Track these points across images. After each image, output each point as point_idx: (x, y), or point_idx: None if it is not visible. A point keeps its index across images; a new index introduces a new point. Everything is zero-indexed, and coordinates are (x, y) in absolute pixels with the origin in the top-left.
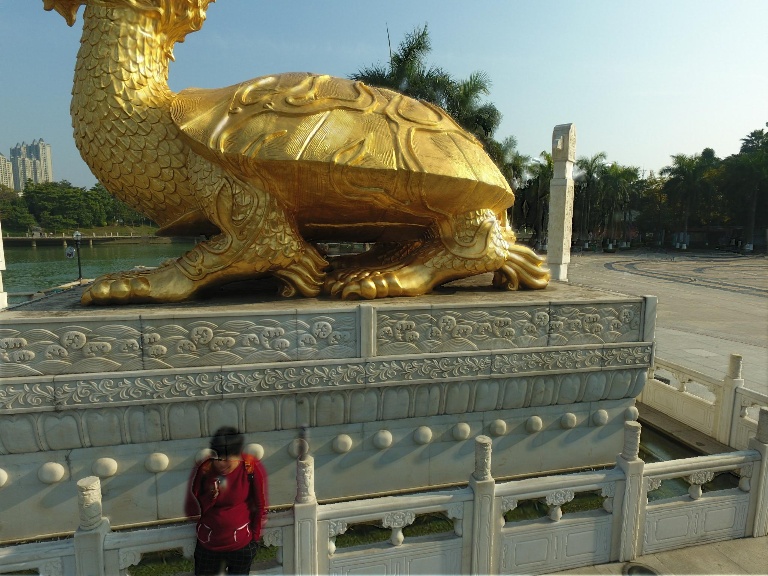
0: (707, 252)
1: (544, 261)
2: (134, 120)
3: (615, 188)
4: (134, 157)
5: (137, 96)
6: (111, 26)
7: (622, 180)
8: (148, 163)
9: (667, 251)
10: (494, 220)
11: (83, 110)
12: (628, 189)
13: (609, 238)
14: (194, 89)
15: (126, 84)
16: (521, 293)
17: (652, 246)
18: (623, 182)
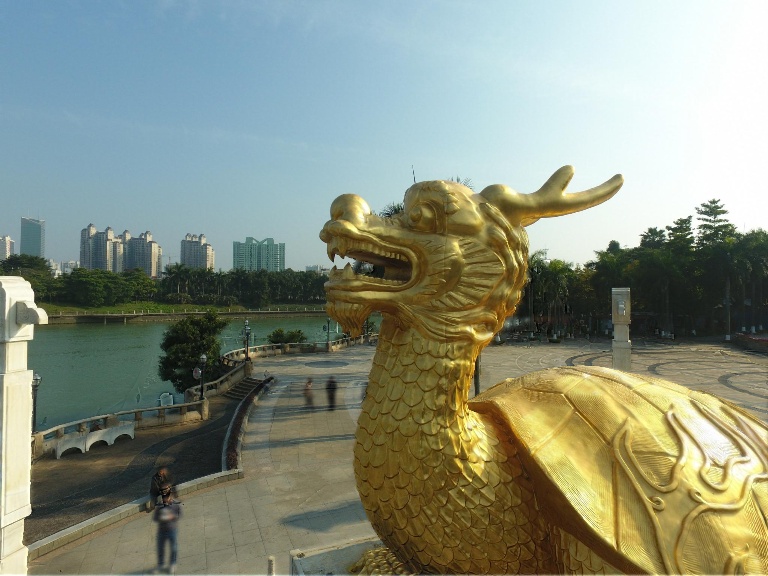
0: (641, 343)
1: (508, 359)
2: (475, 486)
3: (555, 283)
4: (477, 538)
5: (471, 448)
6: (452, 367)
7: (560, 275)
8: (492, 543)
9: (602, 339)
10: None
11: (408, 476)
12: (567, 284)
13: (553, 329)
14: (517, 420)
15: (461, 436)
16: None
17: (589, 335)
18: (561, 277)
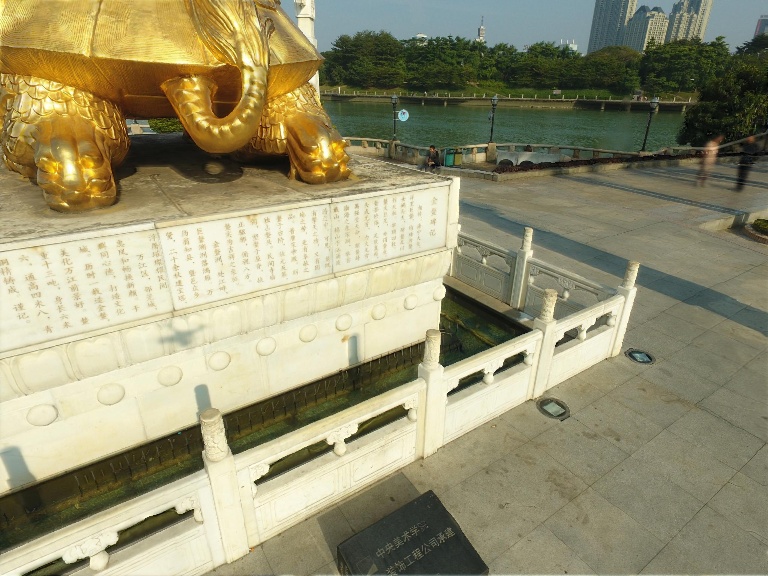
0: None
1: None
2: None
3: None
4: None
5: None
6: None
7: None
8: None
9: None
10: (5, 91)
11: None
12: None
13: None
14: None
15: None
16: (23, 204)
17: None
18: None
